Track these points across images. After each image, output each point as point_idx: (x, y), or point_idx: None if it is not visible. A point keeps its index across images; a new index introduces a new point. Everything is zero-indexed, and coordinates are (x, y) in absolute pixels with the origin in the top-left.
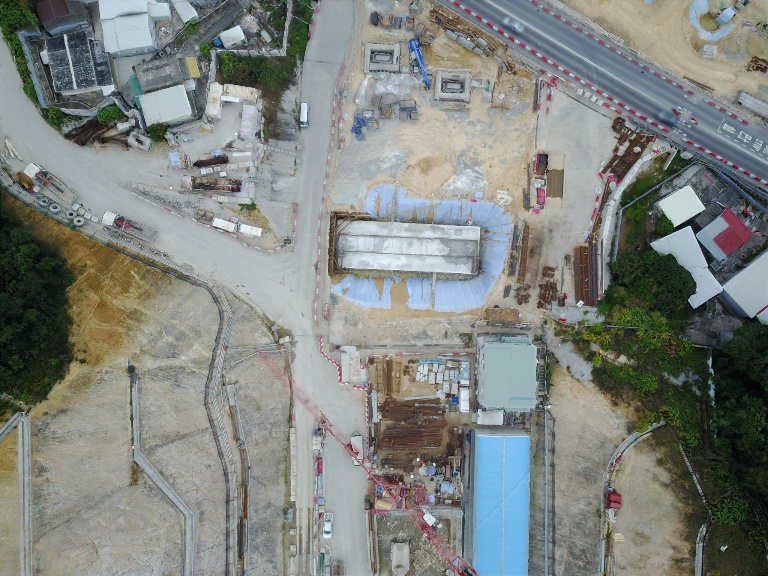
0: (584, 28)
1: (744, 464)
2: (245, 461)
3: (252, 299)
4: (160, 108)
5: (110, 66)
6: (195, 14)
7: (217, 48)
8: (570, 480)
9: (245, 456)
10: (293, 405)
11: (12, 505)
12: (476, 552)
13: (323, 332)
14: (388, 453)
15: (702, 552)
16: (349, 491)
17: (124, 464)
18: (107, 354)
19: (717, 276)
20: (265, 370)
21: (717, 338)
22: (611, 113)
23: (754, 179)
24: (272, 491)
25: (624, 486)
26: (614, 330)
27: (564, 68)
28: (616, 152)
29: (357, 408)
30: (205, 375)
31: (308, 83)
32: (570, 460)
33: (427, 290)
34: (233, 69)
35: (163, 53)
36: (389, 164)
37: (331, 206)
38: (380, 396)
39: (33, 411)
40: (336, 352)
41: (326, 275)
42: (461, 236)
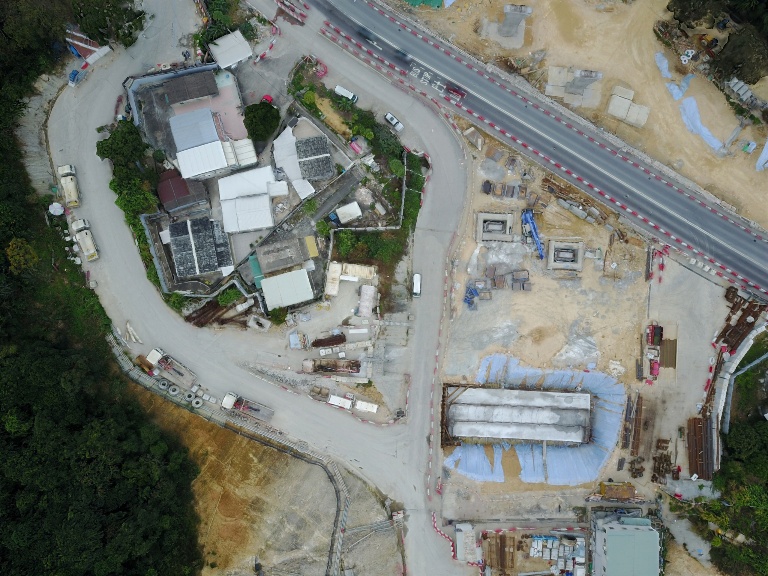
0: (696, 196)
1: None
2: None
3: (365, 473)
4: (282, 292)
5: (230, 246)
6: (313, 191)
7: (333, 222)
8: None
9: None
10: None
11: None
12: None
13: (436, 506)
14: None
15: None
16: None
17: None
18: (235, 554)
19: None
20: (380, 549)
21: None
22: (723, 282)
23: None
24: None
25: None
26: (733, 509)
27: (676, 237)
28: (729, 321)
29: None
30: (325, 562)
31: (420, 252)
32: None
33: (538, 460)
34: (352, 248)
35: (280, 229)
36: (501, 334)
37: (443, 377)
38: (493, 572)
39: None
40: (449, 526)
41: (439, 448)
42: (571, 404)
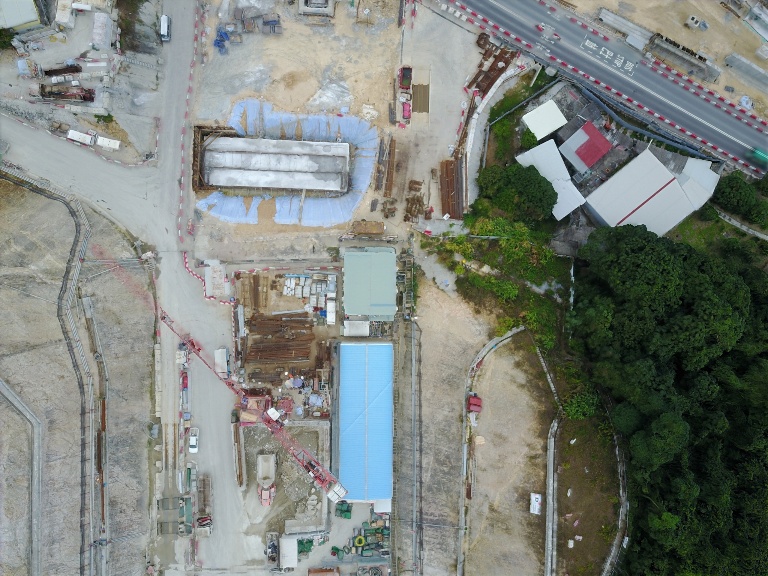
0: None
1: (595, 361)
2: (102, 374)
3: (114, 215)
4: (5, 13)
5: None
6: None
7: None
8: (435, 388)
9: (102, 369)
10: (157, 321)
11: None
12: (341, 460)
13: (188, 248)
14: (255, 367)
15: (554, 447)
16: (216, 406)
17: None
18: None
19: (583, 190)
20: (126, 285)
21: (578, 247)
22: (476, 29)
23: (616, 94)
24: (135, 406)
25: (484, 390)
26: (477, 240)
27: None
28: (481, 67)
29: (224, 323)
30: (58, 286)
31: None
32: (435, 369)
33: (295, 206)
34: None
35: None
36: (254, 79)
37: (195, 121)
38: (247, 311)
39: None
40: (202, 268)
41: (190, 190)
42: (330, 152)
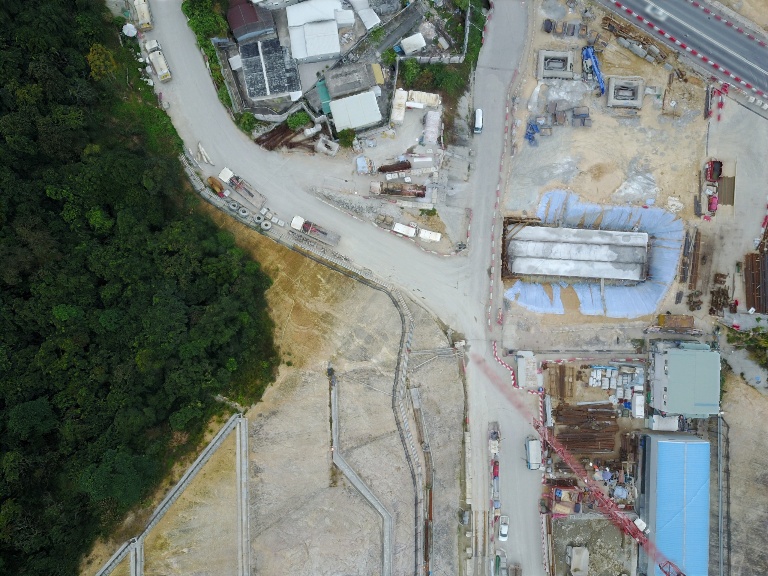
0: (755, 36)
1: None
2: (430, 464)
3: (427, 303)
4: (350, 114)
5: (298, 72)
6: (378, 21)
7: (397, 55)
8: (747, 487)
9: (429, 459)
10: (468, 409)
11: (231, 505)
12: (656, 557)
13: (496, 336)
14: None
15: None
16: (523, 495)
17: (324, 466)
18: (309, 357)
19: None
20: (443, 374)
21: None
22: None
23: None
24: (450, 494)
25: None
26: None
27: (735, 76)
28: None
29: (530, 412)
30: (392, 378)
31: (481, 89)
32: (747, 467)
33: (596, 296)
34: (417, 76)
35: (346, 59)
36: (561, 170)
37: (504, 212)
38: (553, 401)
39: (249, 413)
40: (509, 356)
41: (499, 280)
42: (629, 242)
